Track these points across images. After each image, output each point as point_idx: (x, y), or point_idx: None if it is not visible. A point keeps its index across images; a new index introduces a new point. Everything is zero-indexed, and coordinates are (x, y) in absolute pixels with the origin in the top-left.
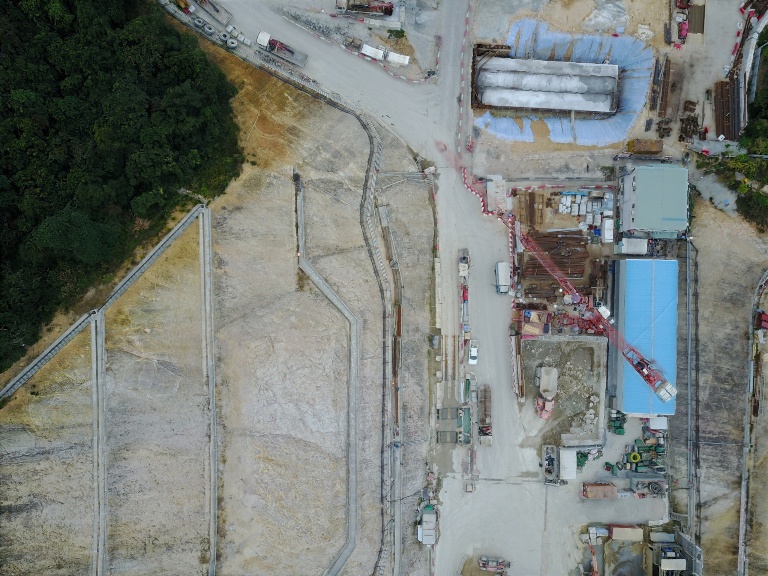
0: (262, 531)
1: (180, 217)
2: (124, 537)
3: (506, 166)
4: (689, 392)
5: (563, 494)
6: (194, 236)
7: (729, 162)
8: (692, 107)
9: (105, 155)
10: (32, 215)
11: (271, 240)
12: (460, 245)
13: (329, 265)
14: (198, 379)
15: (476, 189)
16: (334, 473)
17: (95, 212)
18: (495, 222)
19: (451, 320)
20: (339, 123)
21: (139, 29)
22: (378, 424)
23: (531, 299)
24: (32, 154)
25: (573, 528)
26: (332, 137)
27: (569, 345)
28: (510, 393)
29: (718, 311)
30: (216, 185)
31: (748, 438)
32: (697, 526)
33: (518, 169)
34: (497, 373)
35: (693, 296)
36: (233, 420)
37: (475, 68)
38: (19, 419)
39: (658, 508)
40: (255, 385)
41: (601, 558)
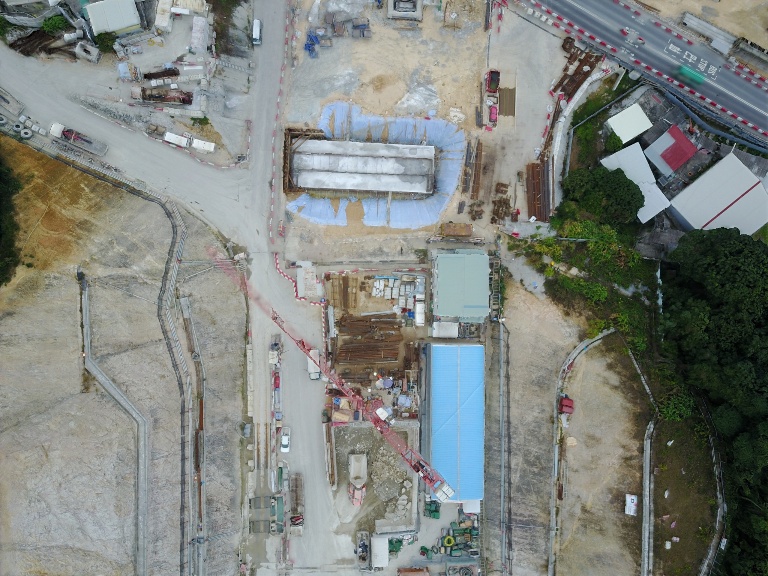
0: None
1: None
2: None
3: (319, 250)
4: (502, 474)
5: None
6: None
7: (536, 245)
8: (504, 189)
9: None
10: None
11: (51, 343)
12: (273, 331)
13: (119, 363)
14: None
15: (289, 274)
16: None
17: None
18: (308, 307)
19: (263, 408)
20: (140, 213)
21: None
22: (175, 523)
23: None
24: None
25: None
26: (130, 229)
27: None
28: (324, 480)
29: (527, 394)
30: None
31: (554, 521)
32: None
33: (332, 253)
34: (311, 460)
35: (505, 378)
36: (0, 535)
37: (286, 152)
38: None
39: None
40: (25, 498)
41: None
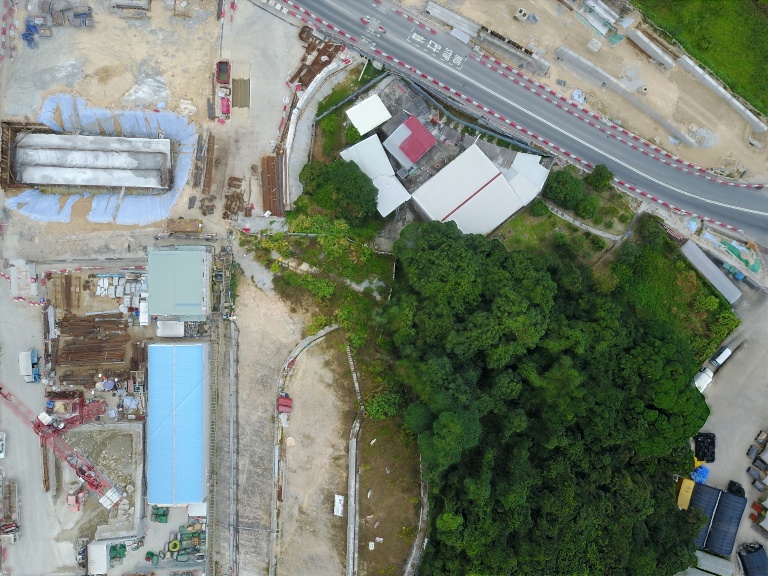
0: None
1: None
2: None
3: (41, 248)
4: (230, 476)
5: None
6: None
7: (262, 241)
8: (237, 183)
9: None
10: None
11: None
12: None
13: None
14: None
15: (7, 273)
16: None
17: None
18: (28, 307)
19: None
20: None
21: None
22: None
23: (67, 386)
24: None
25: None
26: None
27: (101, 434)
28: None
29: (253, 393)
30: None
31: (275, 523)
32: None
33: (54, 251)
34: (30, 465)
35: (235, 377)
36: None
37: (4, 147)
38: None
39: None
40: None
41: None
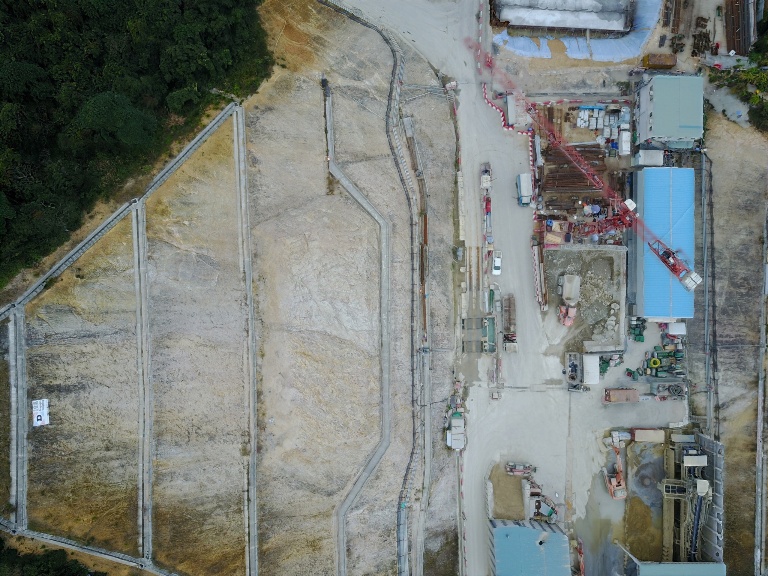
0: (301, 424)
1: (214, 115)
2: (168, 424)
3: (525, 82)
4: (706, 298)
5: (586, 400)
6: (229, 133)
7: (741, 74)
8: (704, 23)
9: (140, 51)
10: (70, 107)
11: (302, 143)
12: (481, 159)
13: (358, 171)
14: (235, 274)
15: (496, 104)
16: (368, 370)
17: (133, 103)
18: (515, 136)
19: (474, 232)
20: (362, 37)
21: None
22: (408, 328)
23: (552, 211)
24: (68, 49)
25: (596, 433)
26: (356, 49)
27: (590, 254)
28: (533, 303)
29: (733, 218)
30: (249, 85)
31: (764, 338)
32: (716, 427)
33: (537, 85)
34: (520, 283)
35: (708, 206)
36: (270, 315)
37: None
38: (65, 301)
39: (678, 410)
40: (291, 281)
41: (624, 461)
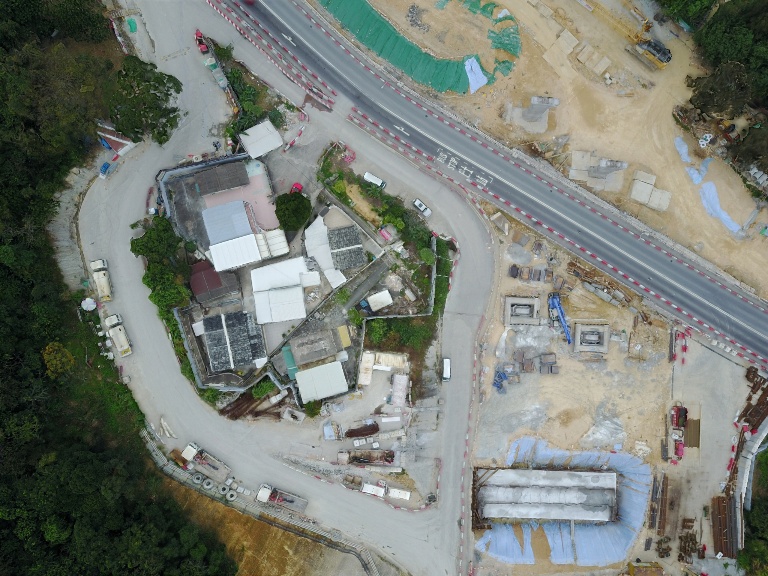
0: None
1: None
2: None
3: None
4: None
5: None
6: None
7: None
8: (690, 524)
9: None
10: None
11: None
12: None
13: None
14: None
15: None
16: None
17: None
18: None
19: None
20: (340, 571)
21: (138, 553)
22: None
23: None
24: None
25: None
26: None
27: None
28: None
29: None
30: None
31: None
32: None
33: None
34: None
35: None
36: None
37: (475, 491)
38: None
39: None
40: None
41: None
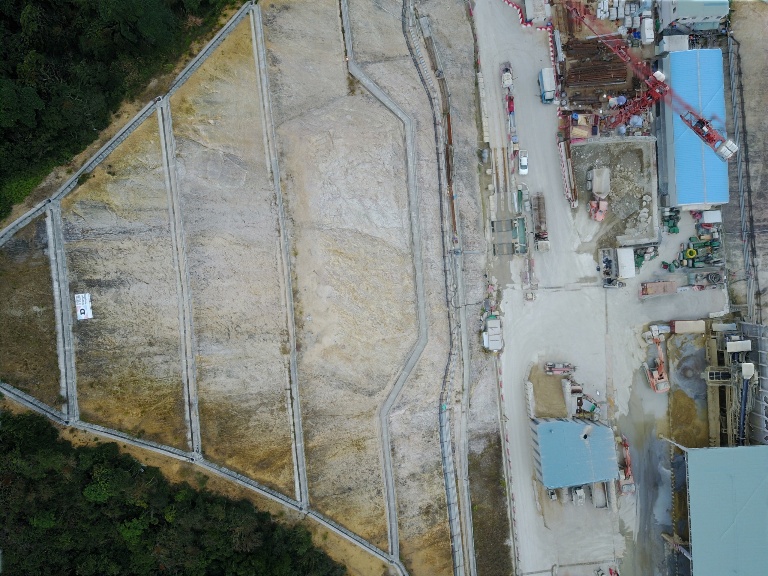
0: (338, 321)
1: (231, 14)
2: (208, 321)
3: None
4: (740, 184)
5: (622, 296)
6: (246, 32)
7: None
8: None
9: None
10: (88, 10)
11: (320, 43)
12: (501, 59)
13: (377, 71)
14: (263, 174)
15: (513, 2)
16: (402, 268)
17: None
18: (534, 33)
19: (498, 133)
20: None
21: None
22: (438, 228)
23: (576, 107)
24: None
25: (635, 328)
26: None
27: (618, 147)
28: (562, 201)
29: (764, 99)
30: None
31: None
32: (758, 314)
33: None
34: (548, 182)
35: (738, 89)
36: (300, 214)
37: None
38: (99, 197)
39: (718, 298)
40: (319, 179)
41: (664, 356)
